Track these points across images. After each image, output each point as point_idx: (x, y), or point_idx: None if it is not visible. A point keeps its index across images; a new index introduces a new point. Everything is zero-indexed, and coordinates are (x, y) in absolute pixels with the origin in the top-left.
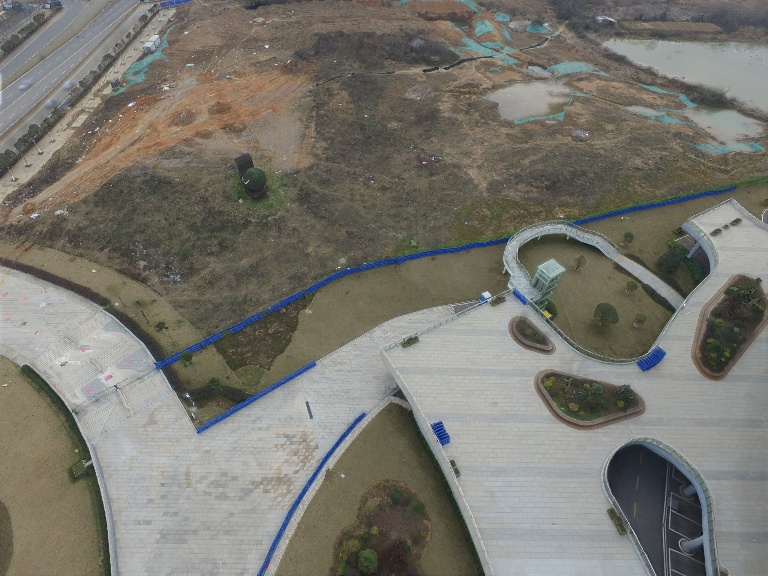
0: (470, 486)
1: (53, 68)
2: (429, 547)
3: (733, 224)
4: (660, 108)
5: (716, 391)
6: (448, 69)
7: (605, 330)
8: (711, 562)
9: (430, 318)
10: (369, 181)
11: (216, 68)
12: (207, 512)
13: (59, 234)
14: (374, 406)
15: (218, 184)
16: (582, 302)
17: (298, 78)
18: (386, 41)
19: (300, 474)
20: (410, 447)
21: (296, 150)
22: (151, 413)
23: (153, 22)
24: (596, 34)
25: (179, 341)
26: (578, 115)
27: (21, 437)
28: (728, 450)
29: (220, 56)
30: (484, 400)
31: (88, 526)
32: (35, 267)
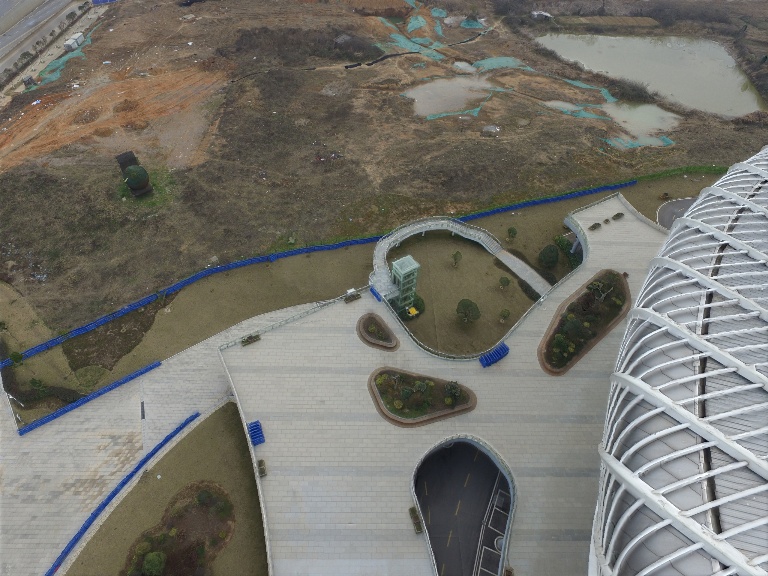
0: (274, 486)
1: None
2: (226, 548)
3: (614, 218)
4: (579, 103)
5: (553, 387)
6: (371, 65)
7: (470, 326)
8: (502, 560)
9: None
10: (261, 178)
11: (132, 65)
12: (9, 516)
13: None
14: (211, 406)
15: (104, 182)
16: (453, 298)
17: (215, 75)
18: (312, 37)
19: (116, 476)
20: (235, 447)
21: (194, 147)
22: None
23: (82, 20)
24: (531, 29)
25: (27, 342)
26: (493, 110)
27: None
28: (550, 446)
29: (140, 53)
30: (312, 398)
31: None
32: None
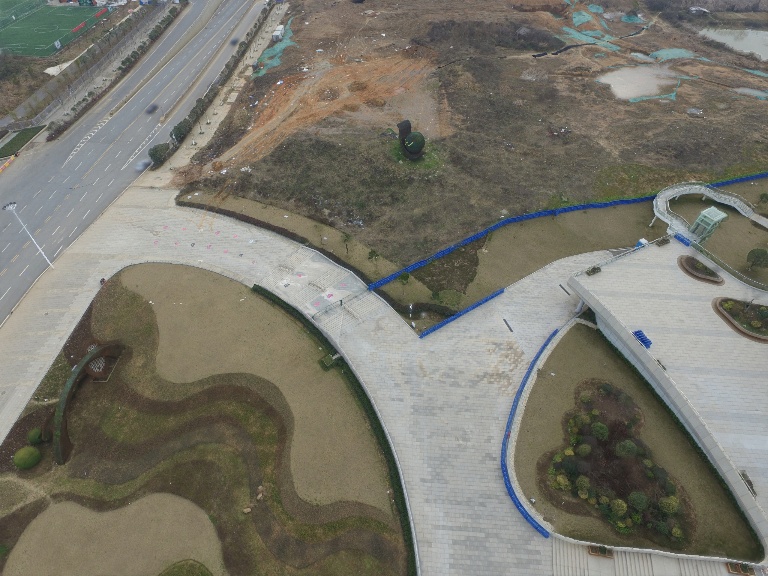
0: (677, 380)
1: (194, 54)
2: (645, 427)
3: None
4: (767, 90)
5: None
6: (556, 54)
7: (755, 275)
8: None
9: (592, 260)
10: (510, 148)
11: (344, 53)
12: (446, 395)
13: (248, 187)
14: (563, 325)
15: (377, 148)
16: (729, 251)
17: (420, 62)
18: (494, 29)
19: (515, 372)
20: (605, 355)
21: (436, 122)
22: (377, 322)
23: None
24: (690, 24)
25: (379, 271)
26: (689, 95)
27: (270, 337)
28: None
29: (344, 43)
30: (671, 318)
31: (349, 402)
32: (236, 212)
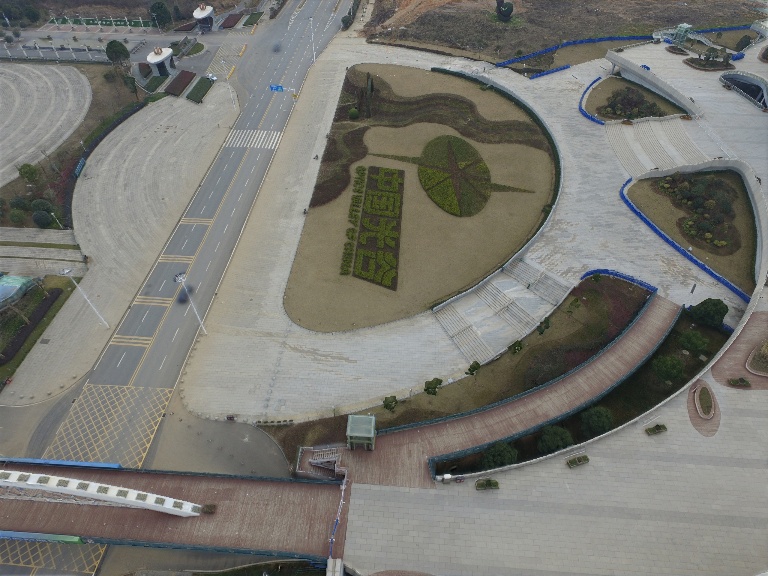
0: None
1: None
2: None
3: None
4: None
5: None
6: None
7: None
8: (767, 95)
9: None
10: None
11: None
12: None
13: (407, 35)
14: None
15: (481, 17)
16: None
17: None
18: None
19: (581, 89)
20: None
21: None
22: None
23: None
24: None
25: None
26: None
27: (450, 83)
28: None
29: None
30: (660, 64)
31: (500, 98)
32: None
